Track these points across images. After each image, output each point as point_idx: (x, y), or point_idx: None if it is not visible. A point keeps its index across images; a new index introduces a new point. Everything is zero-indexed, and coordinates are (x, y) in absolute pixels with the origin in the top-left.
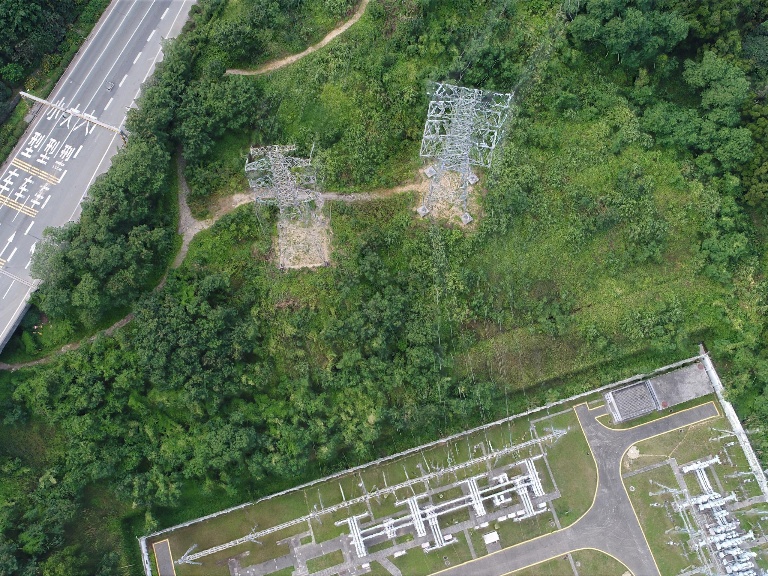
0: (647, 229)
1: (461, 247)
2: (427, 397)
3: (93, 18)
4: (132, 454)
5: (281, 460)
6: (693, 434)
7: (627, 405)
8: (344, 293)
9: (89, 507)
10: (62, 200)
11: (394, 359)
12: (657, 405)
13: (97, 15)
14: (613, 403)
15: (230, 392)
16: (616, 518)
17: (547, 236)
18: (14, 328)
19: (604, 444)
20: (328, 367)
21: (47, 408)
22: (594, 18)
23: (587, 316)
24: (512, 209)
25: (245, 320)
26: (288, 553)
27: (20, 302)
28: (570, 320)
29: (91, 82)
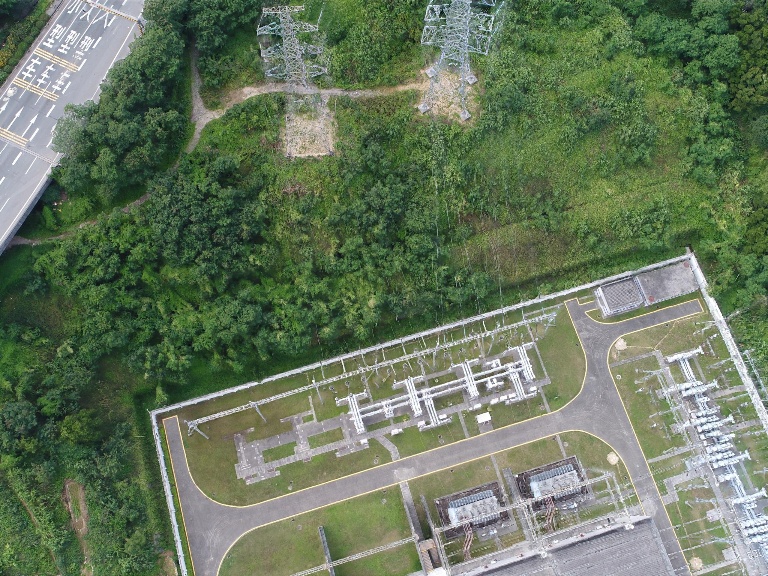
0: (637, 131)
1: (459, 141)
2: (425, 285)
3: None
4: (145, 326)
5: (285, 336)
6: (678, 328)
7: (615, 298)
8: (347, 180)
9: (103, 380)
10: (82, 86)
11: (394, 248)
12: (644, 300)
13: None
14: (602, 297)
15: (238, 270)
16: (603, 403)
17: (541, 135)
18: (36, 200)
19: (593, 336)
20: (331, 252)
21: (66, 279)
22: None
23: (579, 214)
24: (508, 106)
25: (253, 203)
26: (291, 430)
27: (42, 177)
28: (562, 216)
29: None
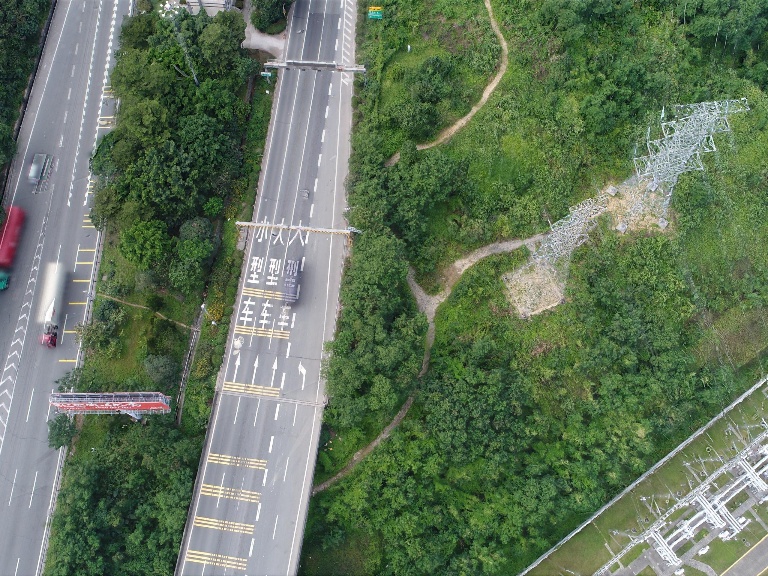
0: None
1: (669, 250)
2: (679, 397)
3: (262, 134)
4: (451, 538)
5: (584, 497)
6: None
7: None
8: (590, 323)
9: None
10: (308, 314)
11: (640, 371)
12: None
13: (264, 130)
14: None
15: (522, 448)
16: None
17: (732, 219)
18: (317, 451)
19: None
20: (590, 397)
21: (365, 519)
22: (714, 15)
23: None
24: (702, 203)
25: (511, 376)
26: None
27: (312, 424)
28: None
29: (285, 195)
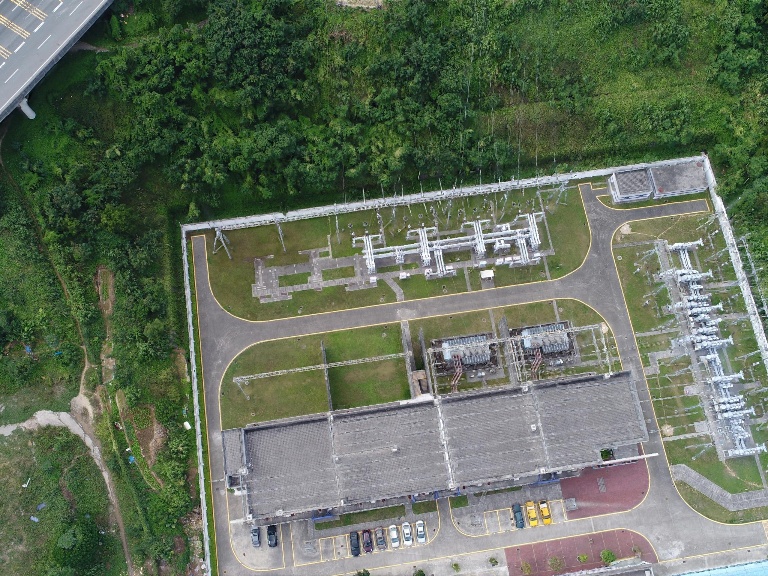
0: (670, 30)
1: (500, 13)
2: (449, 145)
3: None
4: (188, 140)
5: (314, 168)
6: (683, 222)
7: (627, 185)
8: (391, 32)
9: (143, 188)
10: None
11: (425, 106)
12: (654, 191)
13: None
14: (615, 183)
15: (280, 100)
16: (601, 279)
17: (578, 20)
18: (106, 6)
19: (601, 218)
20: (367, 101)
21: (123, 83)
22: None
23: (603, 101)
24: None
25: None
26: (307, 262)
27: None
28: (587, 101)
29: None
